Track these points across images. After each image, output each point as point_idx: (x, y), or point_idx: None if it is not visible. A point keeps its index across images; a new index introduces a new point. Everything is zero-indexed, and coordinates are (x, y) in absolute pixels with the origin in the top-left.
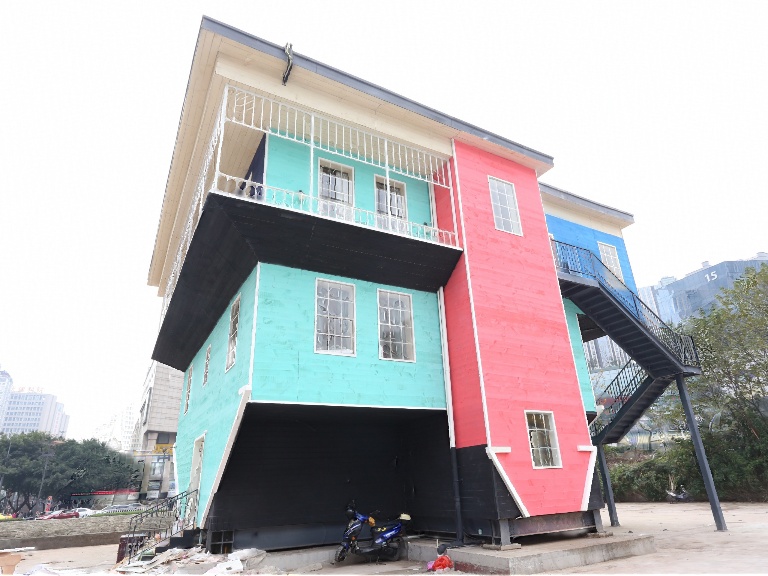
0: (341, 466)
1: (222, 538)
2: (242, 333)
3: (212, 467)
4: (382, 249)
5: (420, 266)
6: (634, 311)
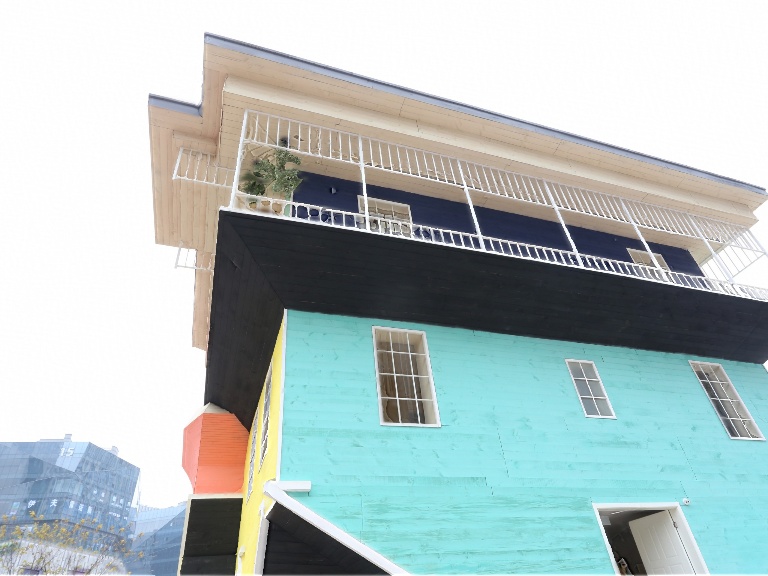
0: None
1: None
2: (766, 415)
3: None
4: None
5: None
6: None
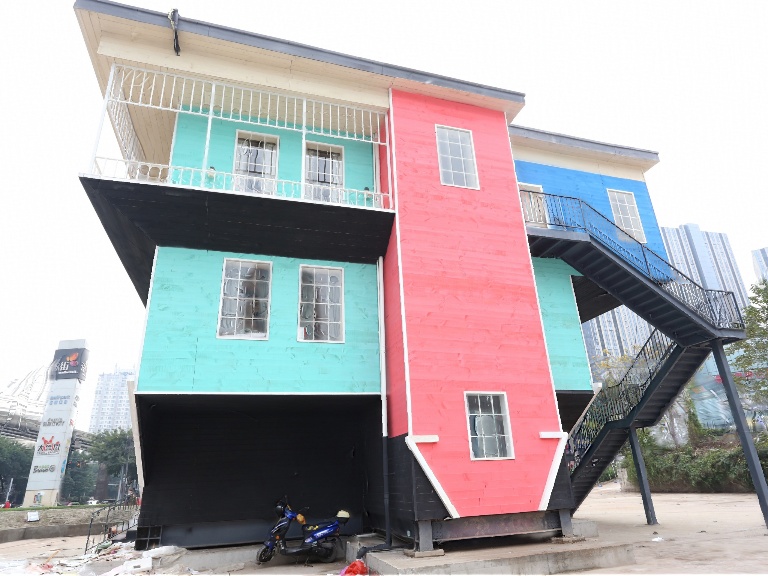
0: (287, 458)
1: (148, 534)
2: None
3: None
4: (295, 220)
5: (347, 235)
6: (642, 266)
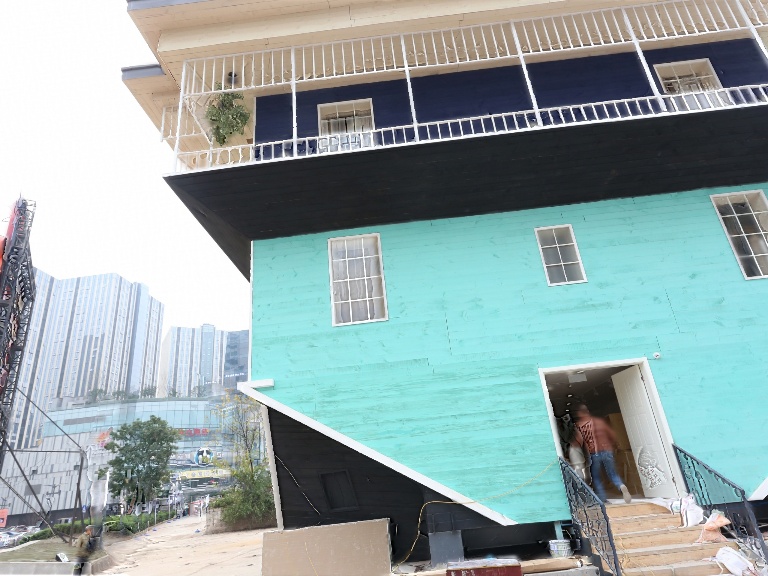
0: None
1: None
2: None
3: (759, 405)
4: None
5: None
6: None
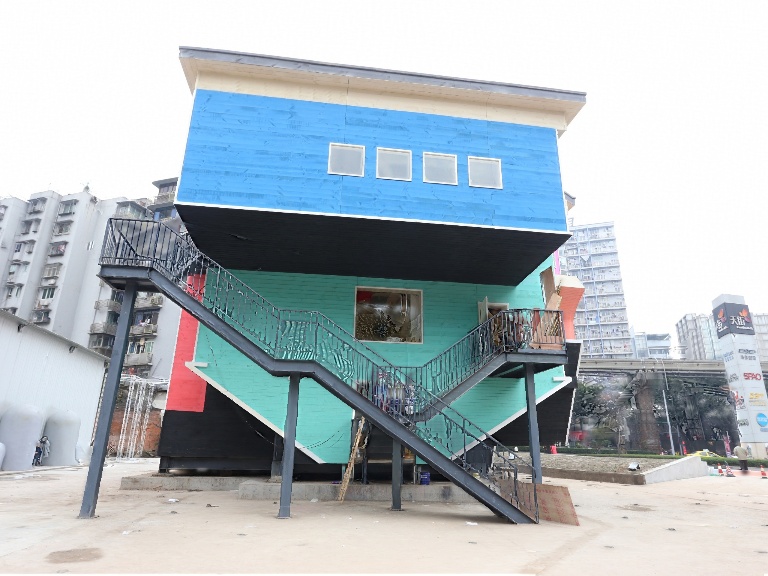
0: None
1: None
2: None
3: None
4: None
5: None
6: None
